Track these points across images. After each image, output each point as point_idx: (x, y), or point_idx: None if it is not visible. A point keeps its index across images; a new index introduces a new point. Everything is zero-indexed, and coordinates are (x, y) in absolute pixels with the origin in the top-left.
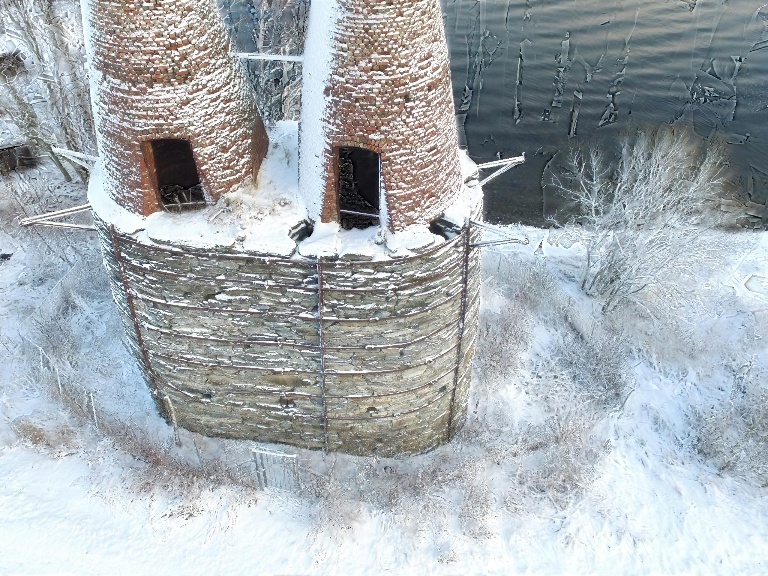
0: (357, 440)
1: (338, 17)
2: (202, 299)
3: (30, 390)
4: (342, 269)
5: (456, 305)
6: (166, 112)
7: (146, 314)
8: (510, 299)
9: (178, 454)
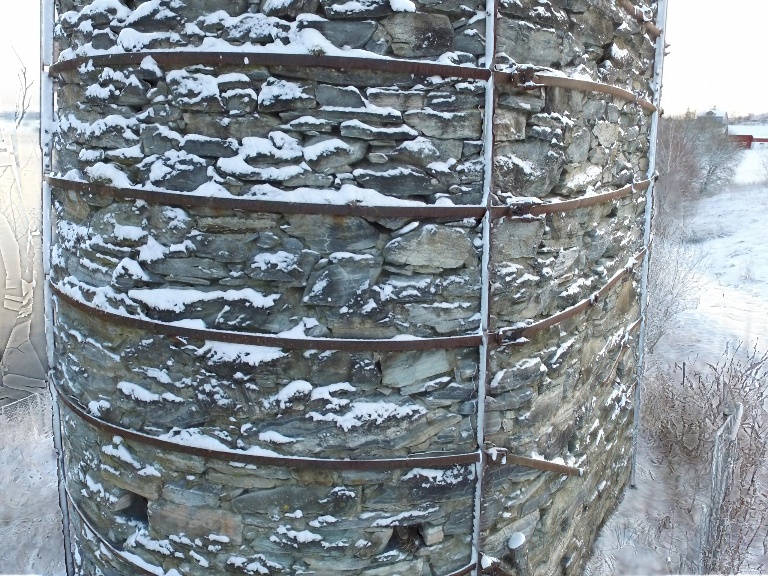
0: None
1: None
2: None
3: None
4: None
5: None
6: None
7: (517, 158)
8: None
9: None
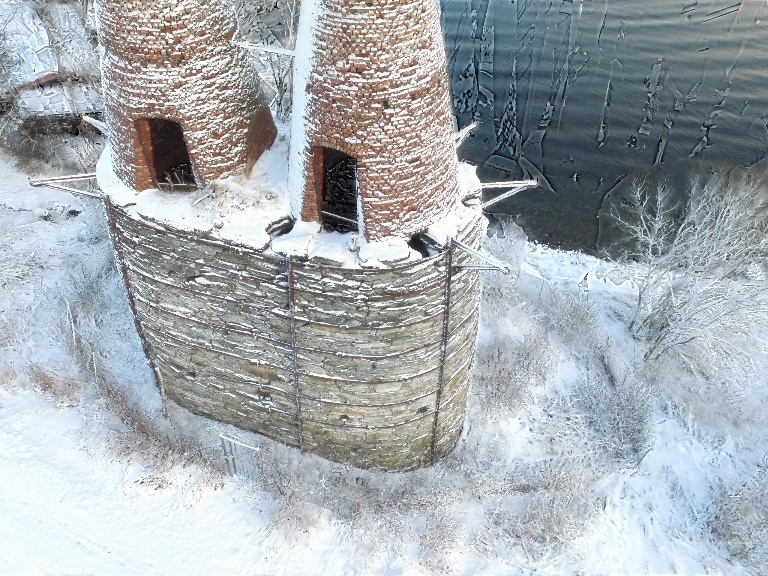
0: (331, 445)
1: (319, 14)
2: (185, 279)
3: (55, 339)
4: (312, 271)
5: (437, 326)
6: (158, 93)
7: (138, 286)
8: (536, 329)
9: (162, 425)
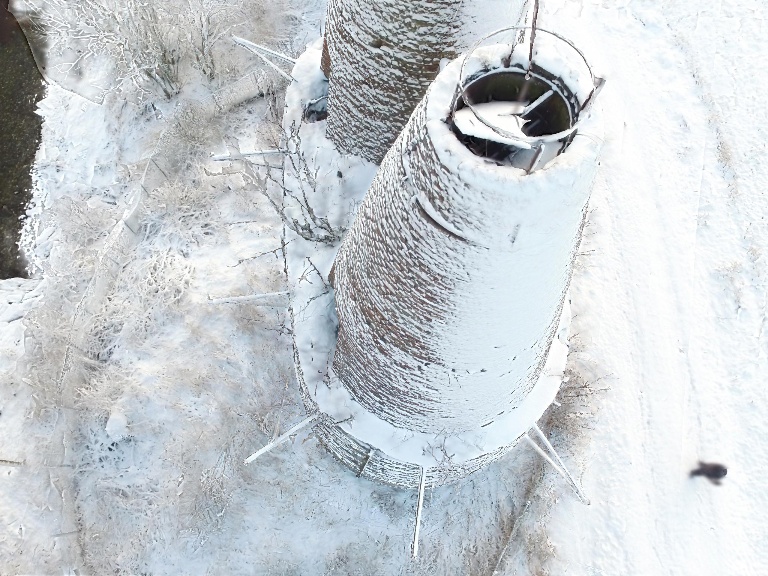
0: None
1: None
2: None
3: None
4: None
5: None
6: None
7: None
8: (258, 135)
9: None
